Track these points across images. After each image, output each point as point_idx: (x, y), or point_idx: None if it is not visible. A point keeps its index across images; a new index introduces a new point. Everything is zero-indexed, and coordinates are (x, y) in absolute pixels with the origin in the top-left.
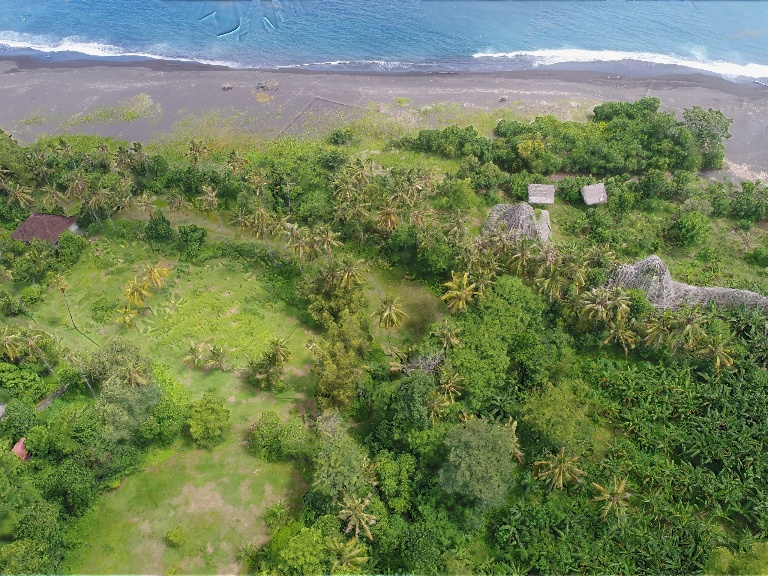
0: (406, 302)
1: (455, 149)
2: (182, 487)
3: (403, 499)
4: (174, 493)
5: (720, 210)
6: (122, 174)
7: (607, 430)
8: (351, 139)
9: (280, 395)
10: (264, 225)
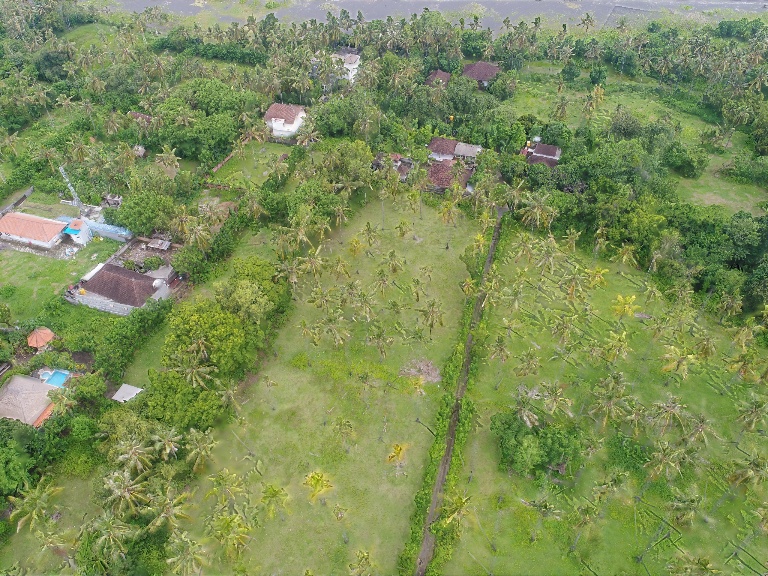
0: None
1: None
2: (692, 194)
3: None
4: (689, 196)
5: None
6: None
7: None
8: (660, 30)
9: (722, 155)
10: (669, 62)
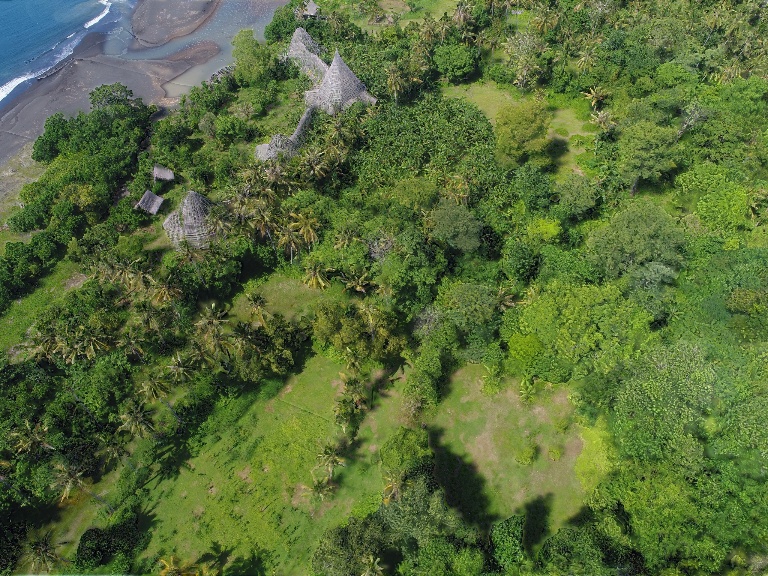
0: None
1: None
2: (474, 474)
3: None
4: (482, 480)
5: None
6: None
7: None
8: None
9: (369, 403)
10: None
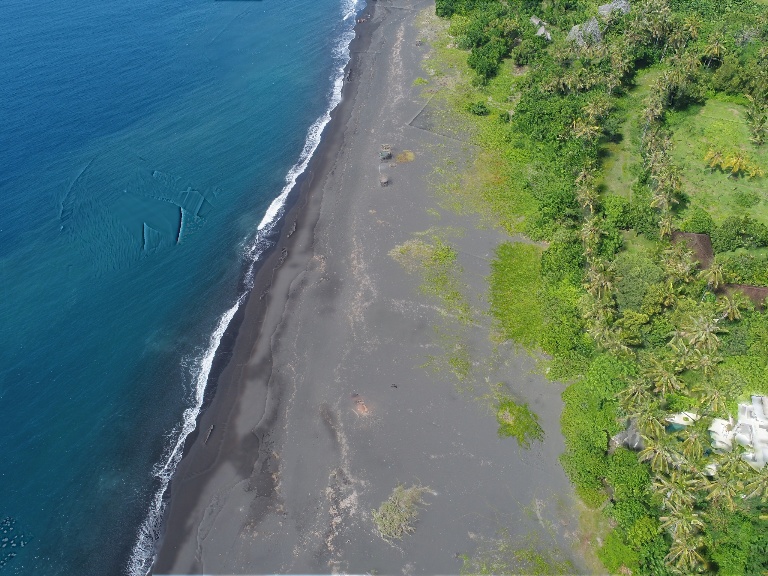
0: None
1: None
2: None
3: None
4: None
5: None
6: None
7: None
8: None
9: None
10: None
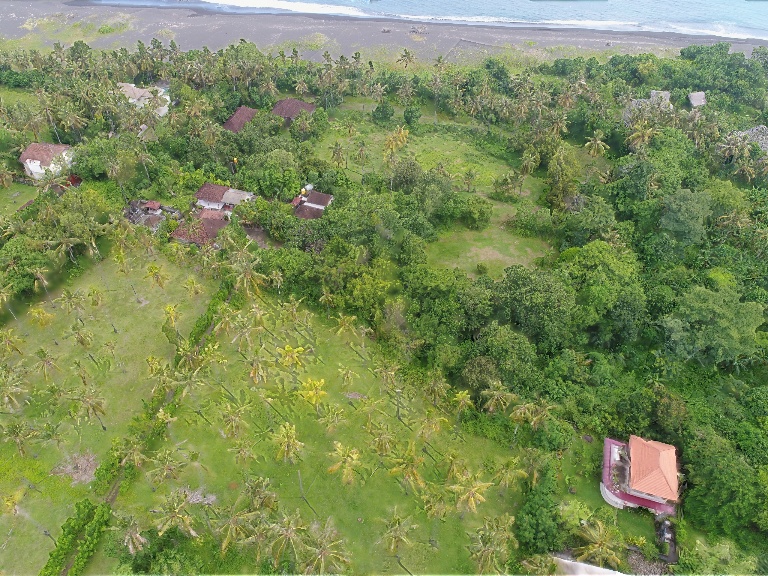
0: (581, 159)
1: (583, 73)
2: (470, 248)
3: (628, 248)
4: (466, 251)
5: None
6: (371, 64)
7: None
8: None
9: (515, 204)
10: (477, 103)
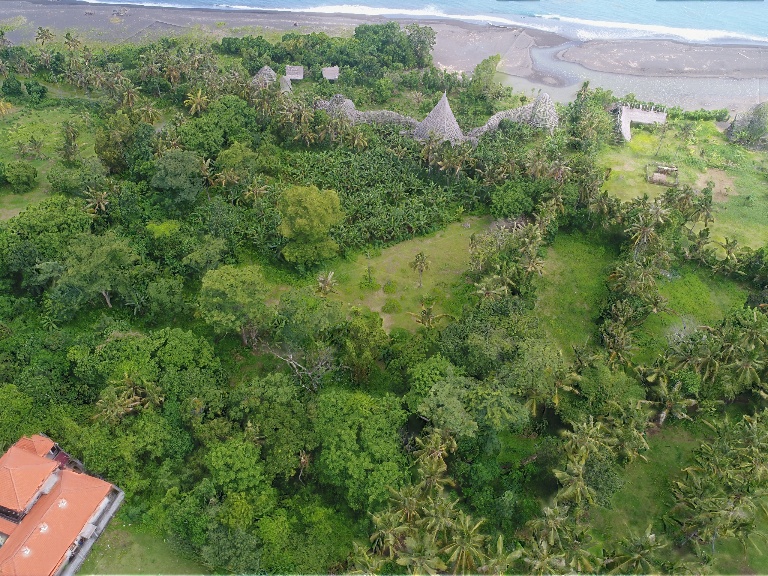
0: None
1: None
2: None
3: None
4: None
5: (412, 84)
6: None
7: (285, 184)
8: (176, 46)
9: None
10: None
